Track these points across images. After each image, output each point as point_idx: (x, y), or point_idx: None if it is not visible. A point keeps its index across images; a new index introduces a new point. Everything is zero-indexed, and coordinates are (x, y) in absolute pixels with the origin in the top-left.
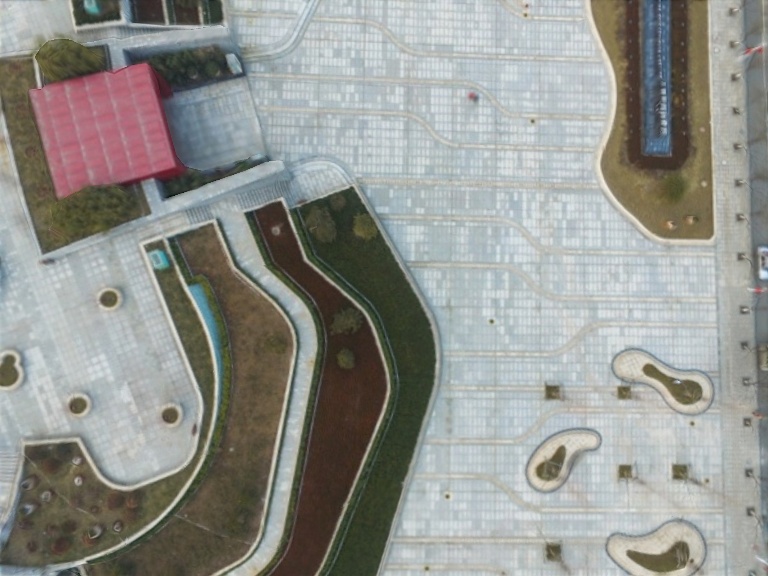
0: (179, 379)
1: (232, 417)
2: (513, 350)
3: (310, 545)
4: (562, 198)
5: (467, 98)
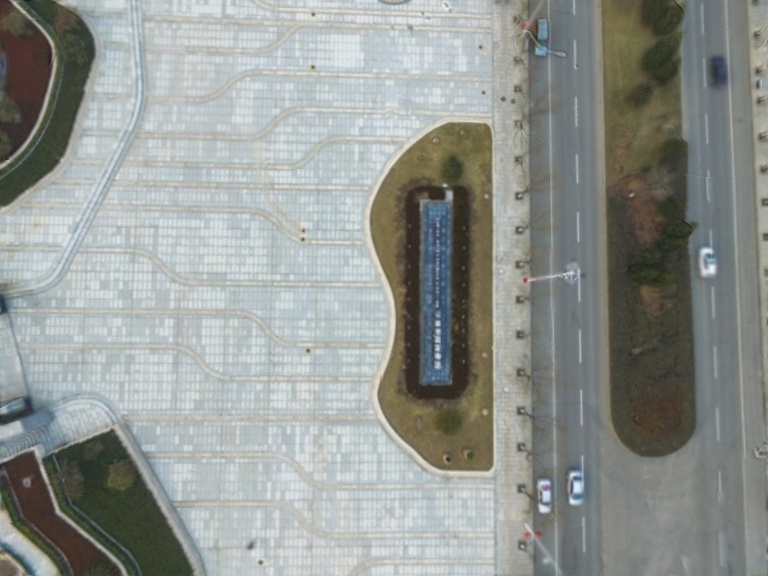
0: None
1: None
2: None
3: None
4: (337, 430)
5: (240, 328)
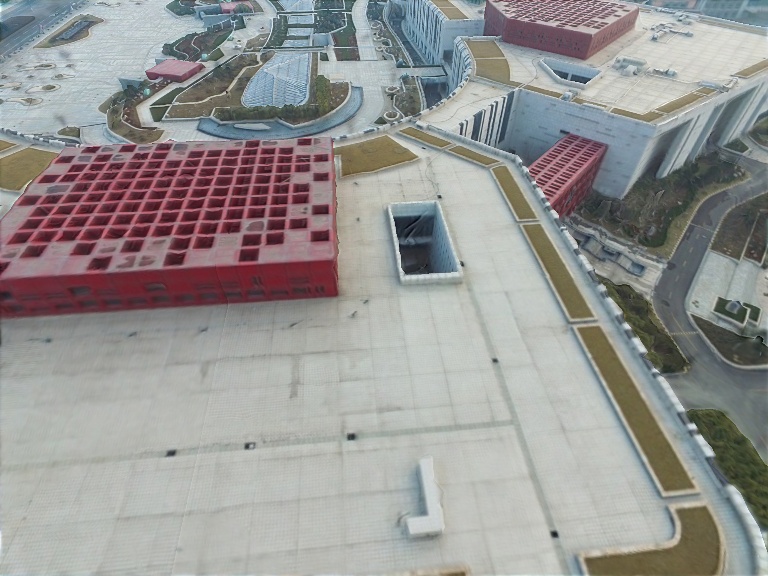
0: None
1: None
2: None
3: None
4: None
5: None
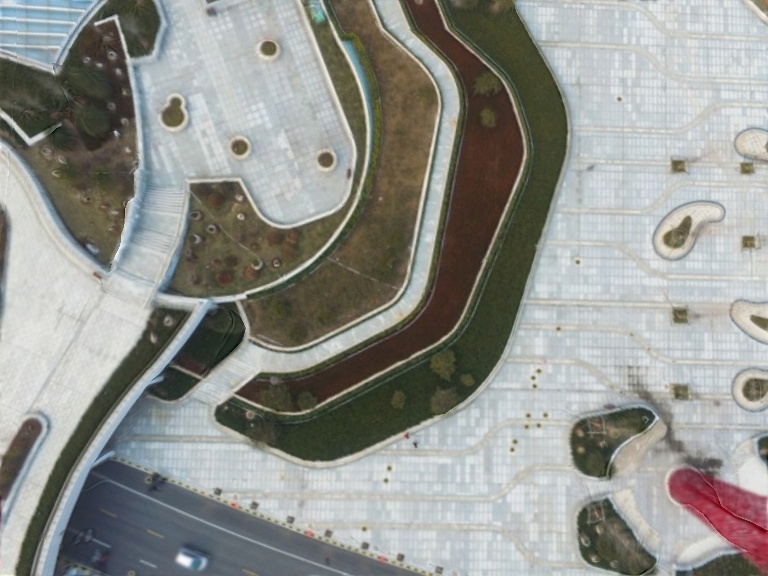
0: (333, 128)
1: (381, 168)
2: (640, 127)
3: (451, 296)
4: None
5: None
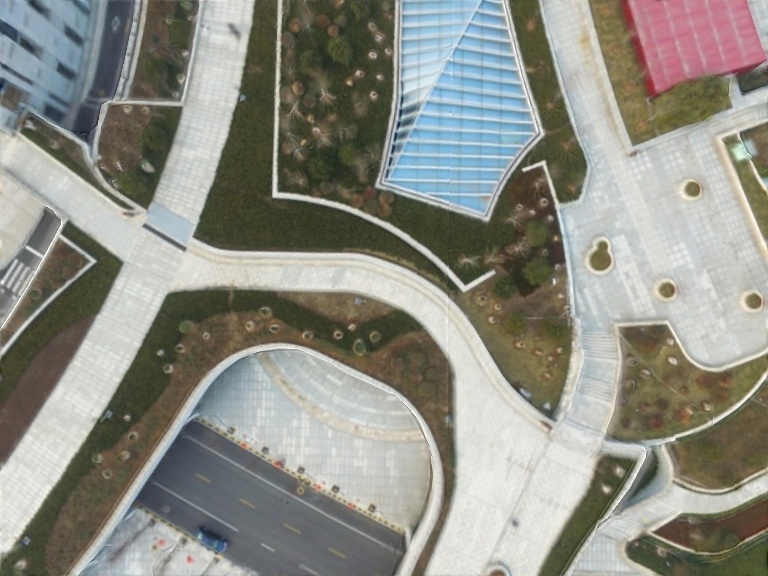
0: (755, 267)
1: None
2: None
3: None
4: None
5: None
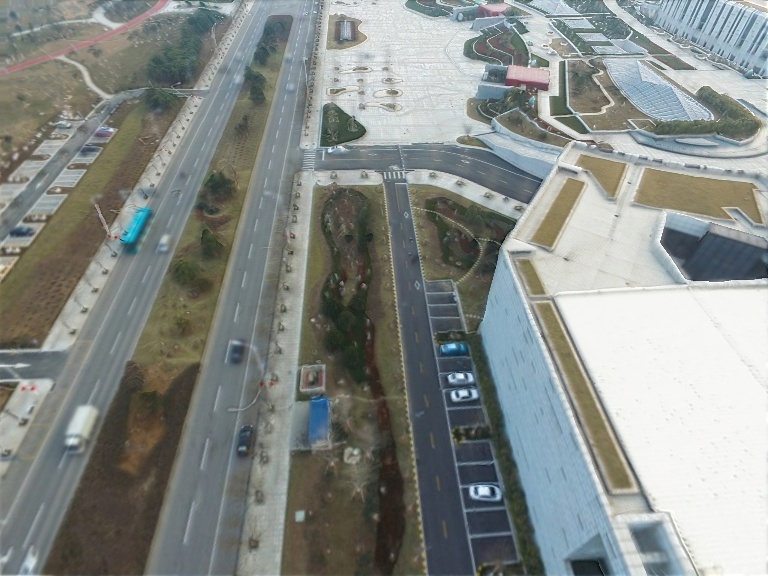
0: None
1: None
2: (385, 7)
3: None
4: None
5: None
